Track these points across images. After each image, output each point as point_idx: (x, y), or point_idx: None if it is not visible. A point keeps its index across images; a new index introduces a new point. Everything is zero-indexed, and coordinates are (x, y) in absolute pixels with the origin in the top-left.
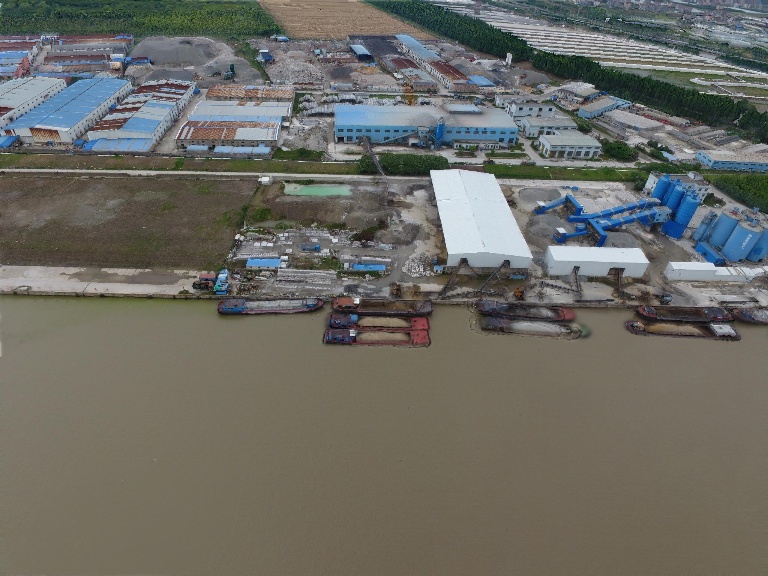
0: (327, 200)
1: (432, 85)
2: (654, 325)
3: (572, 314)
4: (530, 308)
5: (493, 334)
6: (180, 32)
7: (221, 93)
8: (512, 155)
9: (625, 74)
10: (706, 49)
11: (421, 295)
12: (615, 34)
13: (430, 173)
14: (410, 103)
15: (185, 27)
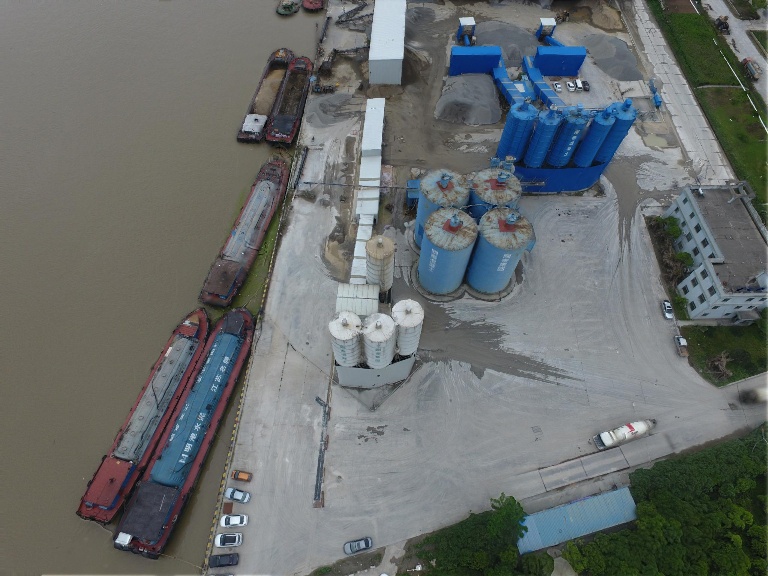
0: None
1: None
2: None
3: None
4: None
5: None
6: None
7: None
8: None
9: None
10: None
11: None
12: None
13: None
14: None
15: None
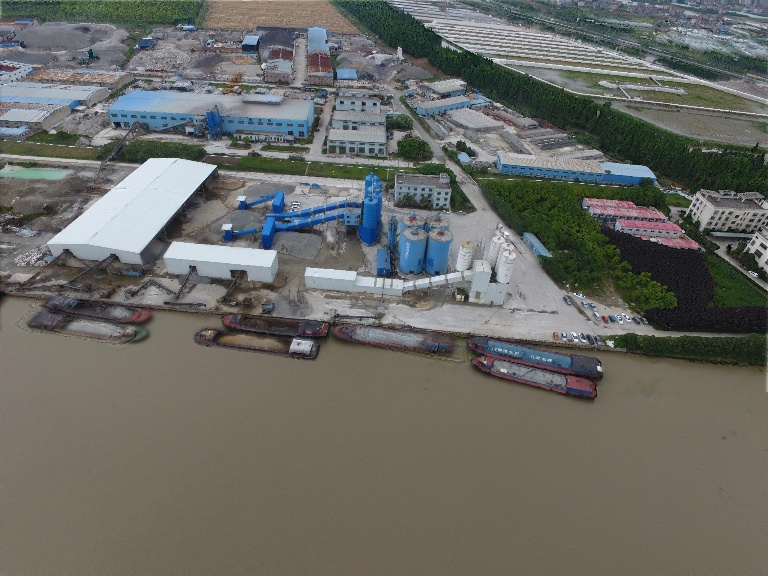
0: (24, 183)
1: (283, 76)
2: (233, 335)
3: (146, 317)
4: (107, 307)
5: (37, 332)
6: (92, 19)
7: (45, 76)
8: (291, 149)
9: (501, 72)
10: (656, 52)
11: (1, 285)
12: (566, 34)
13: (146, 161)
14: (246, 93)
15: (100, 14)
